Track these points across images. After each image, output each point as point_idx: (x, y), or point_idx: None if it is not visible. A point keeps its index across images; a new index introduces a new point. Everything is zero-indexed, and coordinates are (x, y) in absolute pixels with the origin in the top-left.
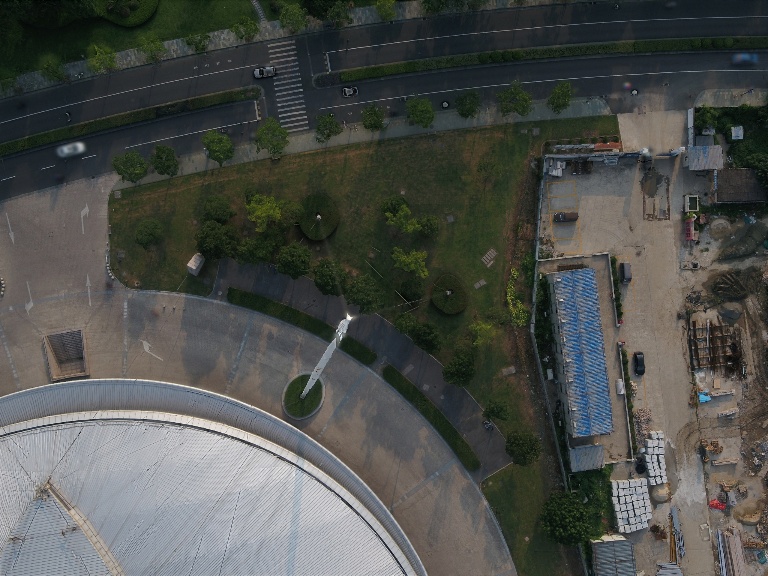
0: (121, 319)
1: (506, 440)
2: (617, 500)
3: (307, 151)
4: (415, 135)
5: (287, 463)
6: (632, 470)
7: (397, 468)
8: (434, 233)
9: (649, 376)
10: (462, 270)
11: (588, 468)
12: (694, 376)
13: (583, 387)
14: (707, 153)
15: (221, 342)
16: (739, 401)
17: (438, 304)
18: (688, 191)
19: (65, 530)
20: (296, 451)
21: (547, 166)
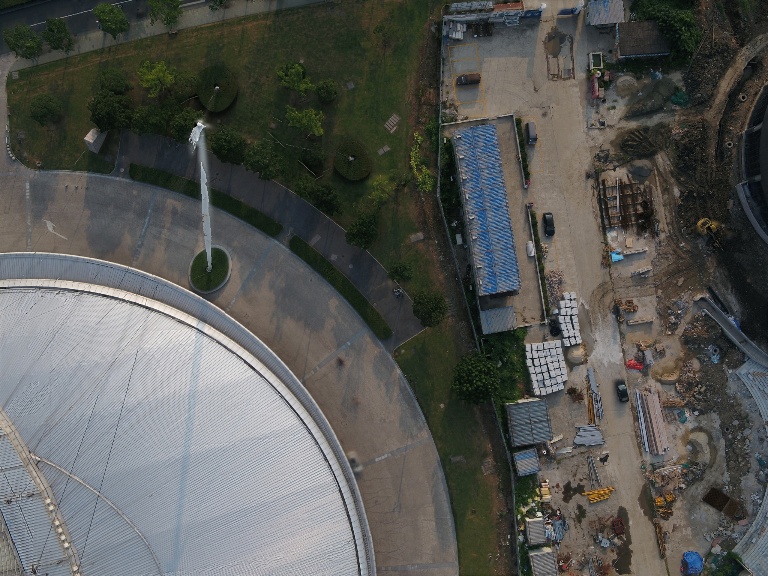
0: (24, 200)
1: None
2: (531, 362)
3: (204, 24)
4: (313, 4)
5: (187, 326)
6: (546, 333)
7: (308, 339)
8: (331, 96)
9: (560, 237)
10: (365, 136)
11: (499, 330)
12: (606, 236)
13: (488, 244)
14: (608, 7)
15: (125, 219)
16: (653, 259)
17: (341, 171)
18: (592, 49)
19: None
20: (198, 317)
21: (447, 29)
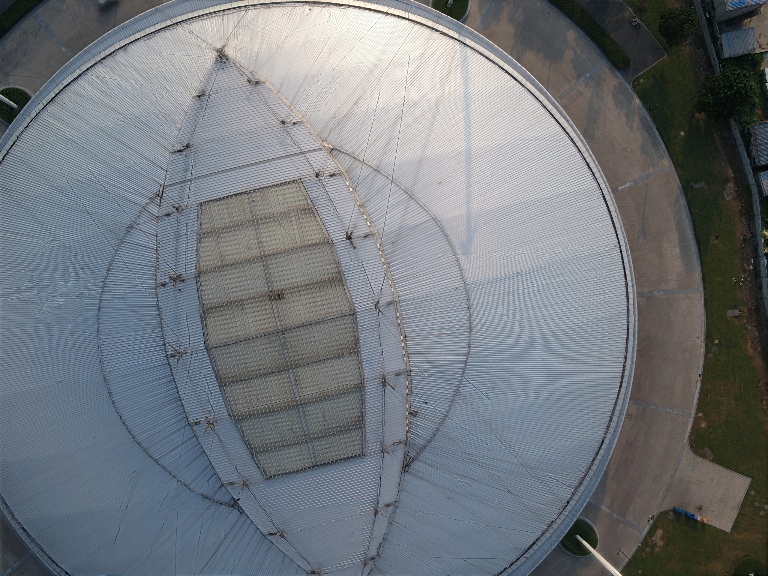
0: None
1: (654, 36)
2: None
3: None
4: None
5: (450, 38)
6: None
7: (548, 71)
8: None
9: None
10: None
11: (741, 52)
12: None
13: None
14: None
15: None
16: None
17: None
18: None
19: (248, 84)
20: None
21: None
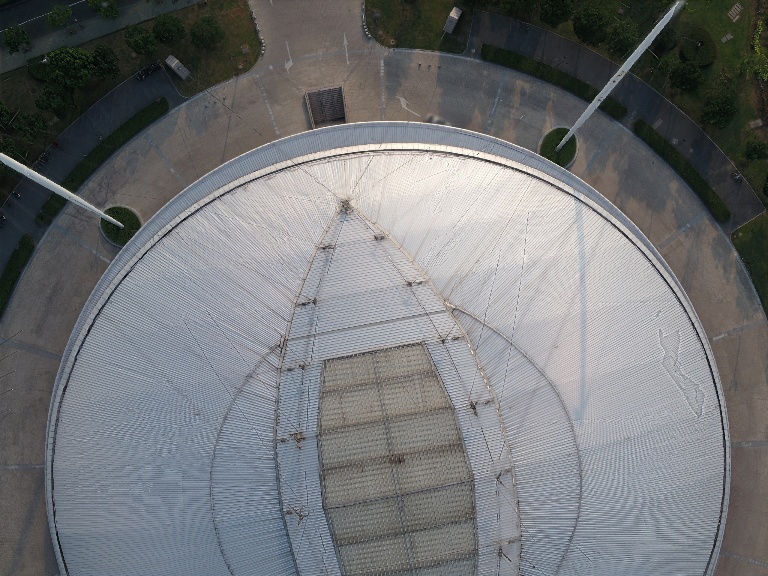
0: (378, 77)
1: (755, 192)
2: None
3: None
4: None
5: (565, 193)
6: None
7: (650, 220)
8: None
9: None
10: (709, 24)
11: None
12: None
13: None
14: None
15: (476, 98)
16: None
17: (689, 56)
18: None
19: (374, 239)
20: None
21: None
